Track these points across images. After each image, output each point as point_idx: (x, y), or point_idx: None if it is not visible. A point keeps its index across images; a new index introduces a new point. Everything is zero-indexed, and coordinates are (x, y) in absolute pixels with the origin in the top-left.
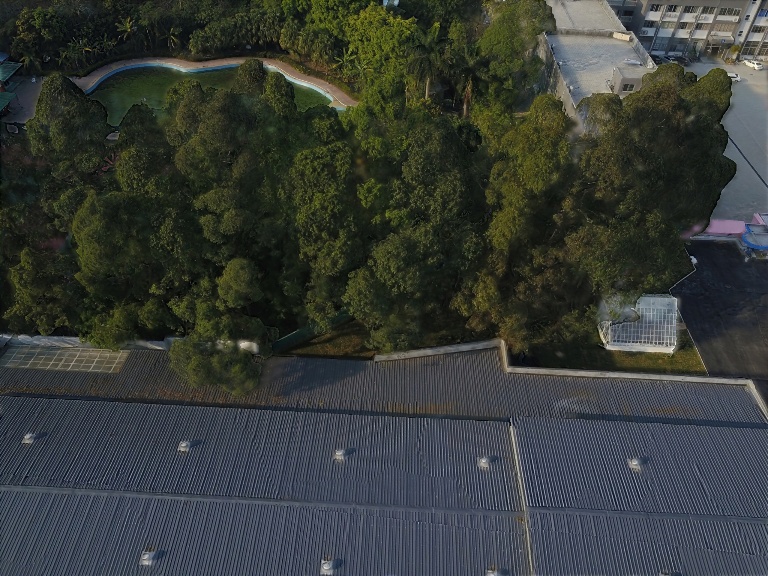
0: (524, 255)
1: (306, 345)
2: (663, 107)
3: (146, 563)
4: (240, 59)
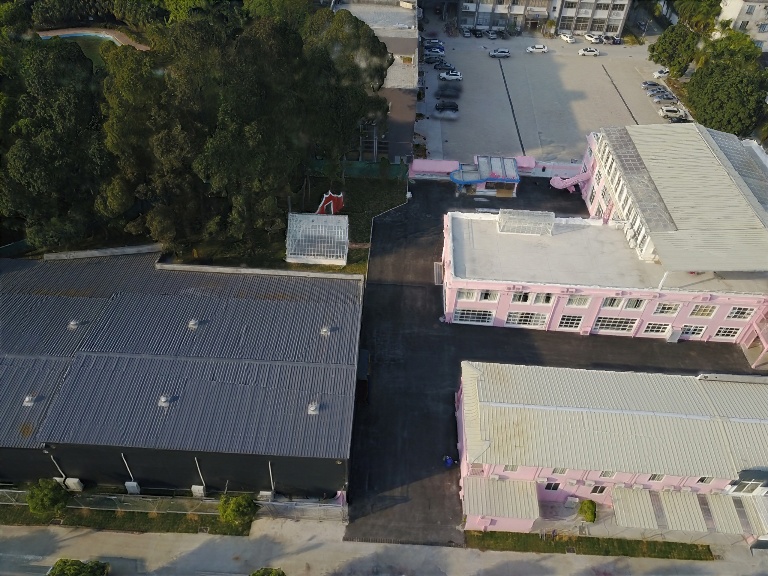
0: (158, 164)
1: (19, 256)
2: (259, 35)
3: None
4: (81, 29)
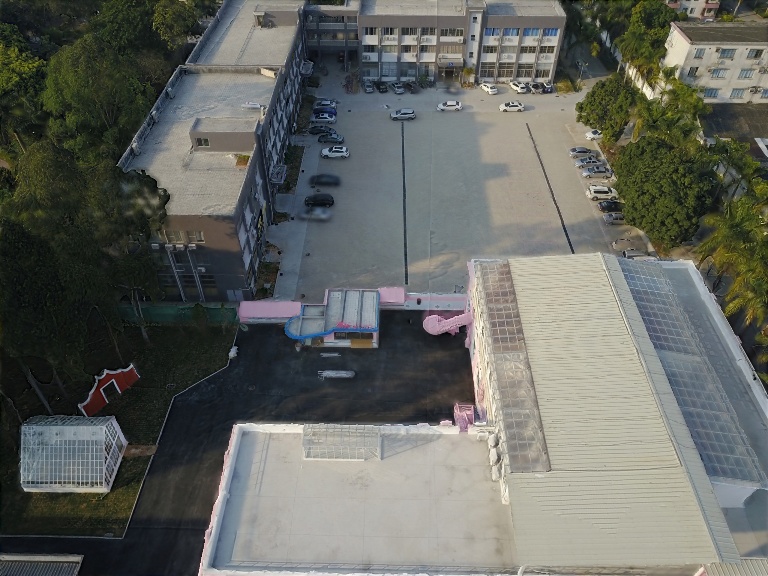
0: None
1: None
2: None
3: None
4: None
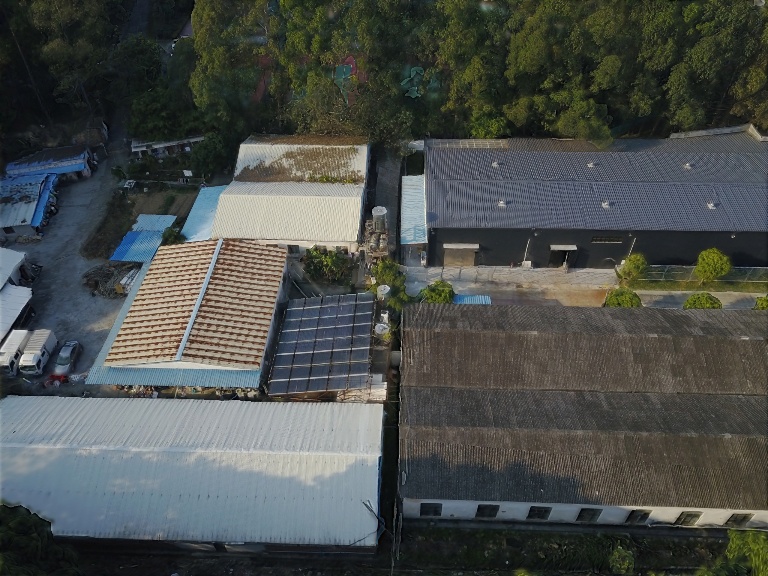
0: None
1: None
2: None
3: (607, 207)
4: None
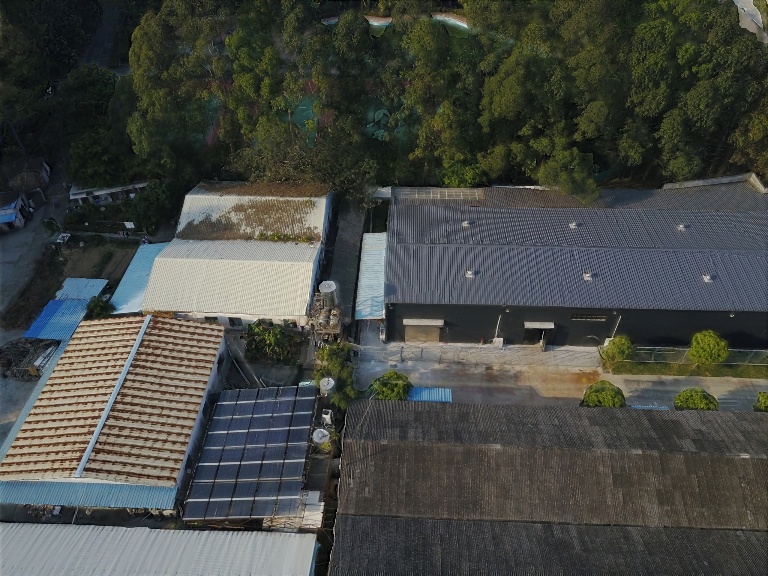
0: None
1: None
2: None
3: (589, 279)
4: None
